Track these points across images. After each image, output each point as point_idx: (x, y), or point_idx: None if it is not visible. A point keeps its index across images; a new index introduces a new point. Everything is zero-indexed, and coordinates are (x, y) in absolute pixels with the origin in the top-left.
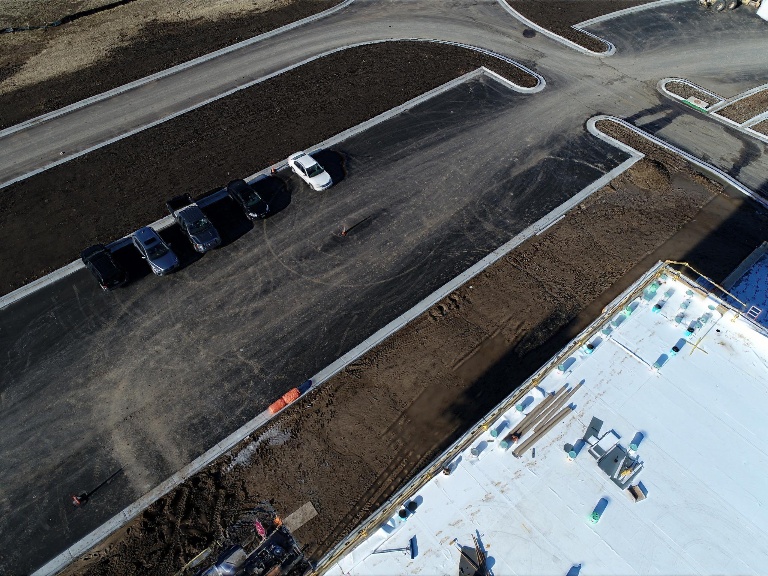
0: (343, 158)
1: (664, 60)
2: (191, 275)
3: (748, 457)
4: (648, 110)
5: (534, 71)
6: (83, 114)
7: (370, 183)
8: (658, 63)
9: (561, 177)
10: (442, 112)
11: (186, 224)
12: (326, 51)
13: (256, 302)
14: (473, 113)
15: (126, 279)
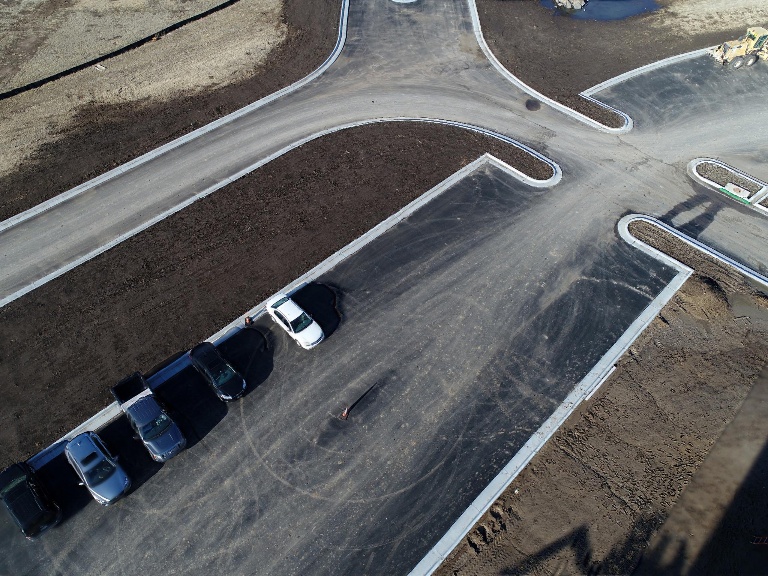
0: (334, 295)
1: (689, 135)
2: (148, 499)
3: None
4: (684, 204)
5: (546, 156)
6: (2, 243)
7: (371, 331)
8: (683, 139)
9: (601, 308)
10: (447, 219)
11: (138, 427)
12: (301, 139)
13: (238, 539)
14: (484, 219)
15: (58, 519)
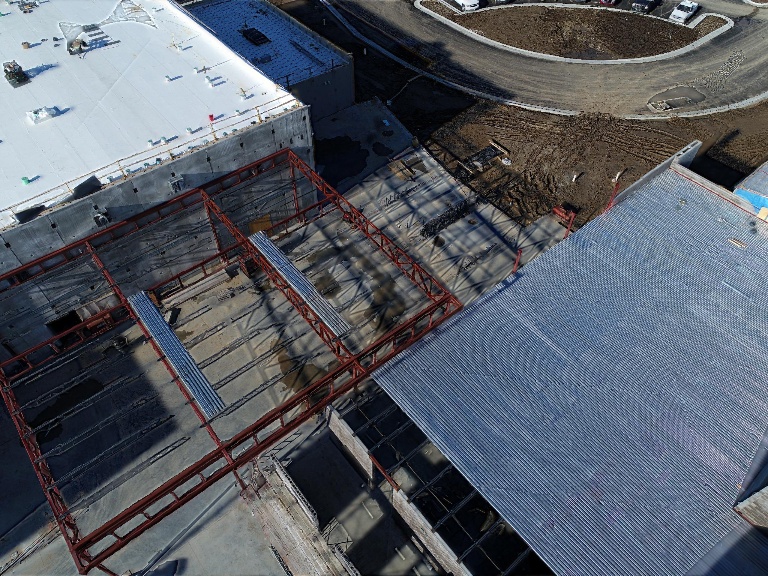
0: None
1: None
2: None
3: (89, 7)
4: None
5: None
6: None
7: None
8: None
9: None
10: None
11: None
12: None
13: None
14: None
15: None
